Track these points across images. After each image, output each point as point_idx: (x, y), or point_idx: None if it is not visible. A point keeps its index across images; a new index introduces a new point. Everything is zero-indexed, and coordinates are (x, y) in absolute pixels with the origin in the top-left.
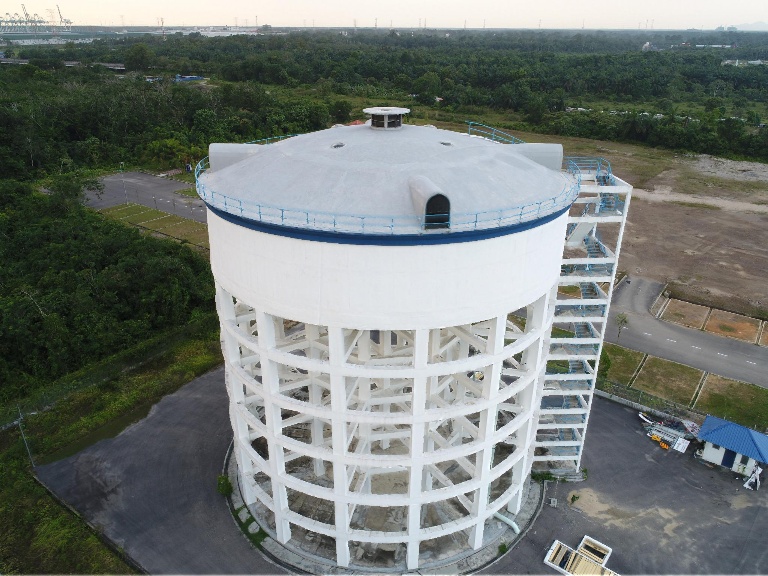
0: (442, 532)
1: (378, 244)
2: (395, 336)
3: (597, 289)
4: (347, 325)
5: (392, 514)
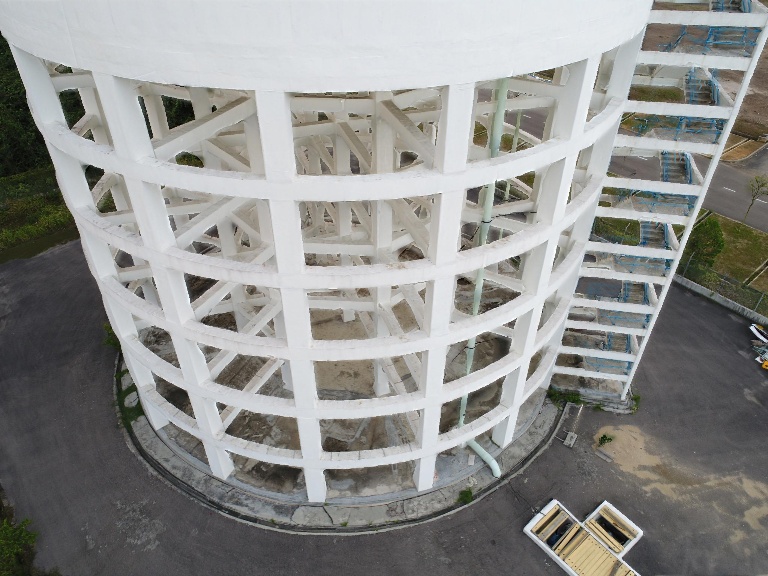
0: (358, 462)
1: None
2: None
3: (717, 92)
4: (120, 69)
5: None
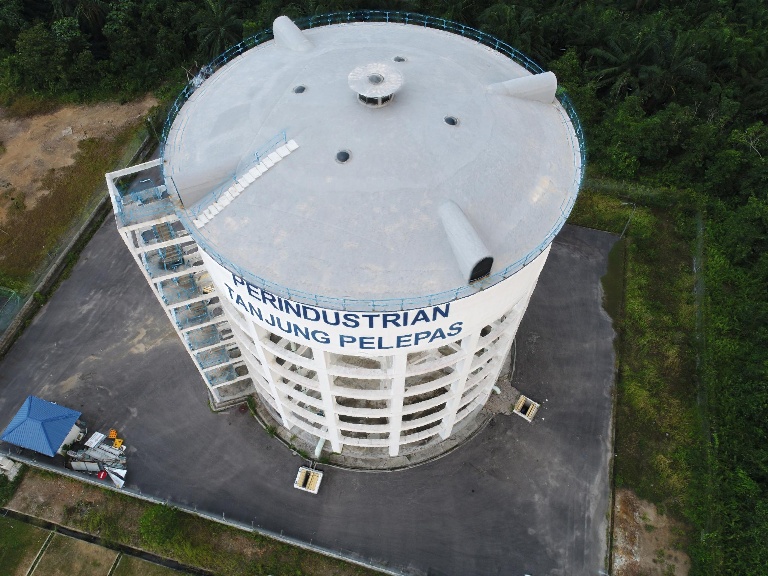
0: None
1: None
2: (454, 555)
3: None
4: None
5: None
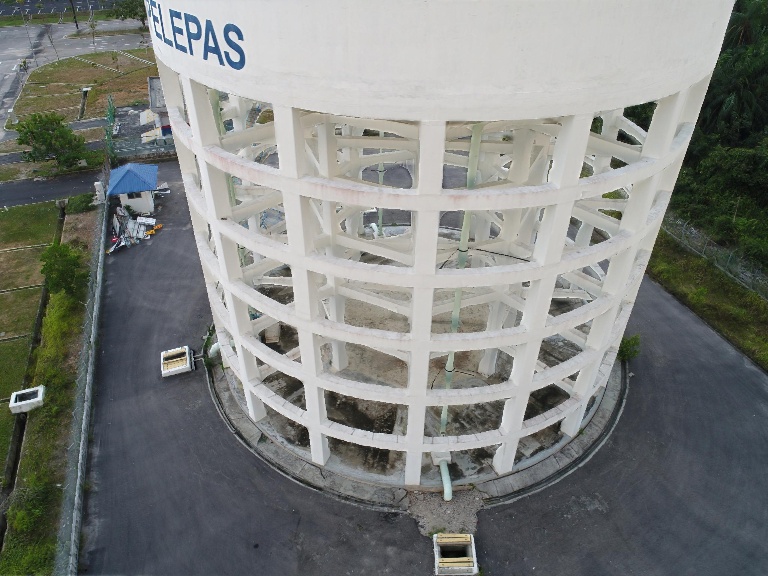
0: None
1: None
2: (136, 571)
3: None
4: None
5: None
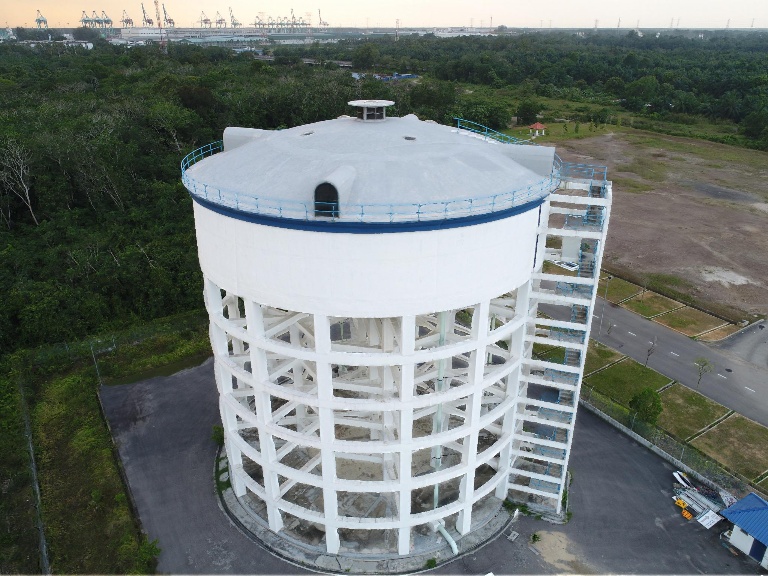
0: (359, 525)
1: (273, 225)
2: None
3: (586, 313)
4: (256, 299)
5: (343, 499)
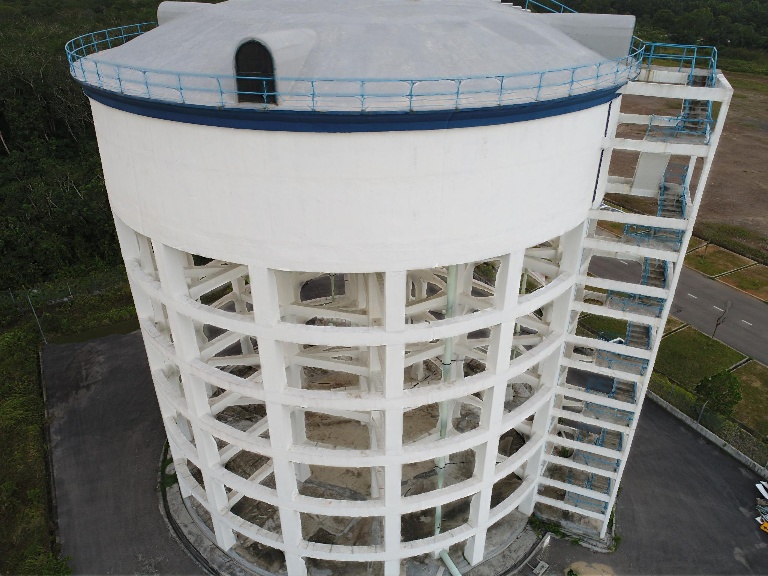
0: (329, 555)
1: (176, 119)
2: None
3: (666, 272)
4: (167, 240)
5: None
